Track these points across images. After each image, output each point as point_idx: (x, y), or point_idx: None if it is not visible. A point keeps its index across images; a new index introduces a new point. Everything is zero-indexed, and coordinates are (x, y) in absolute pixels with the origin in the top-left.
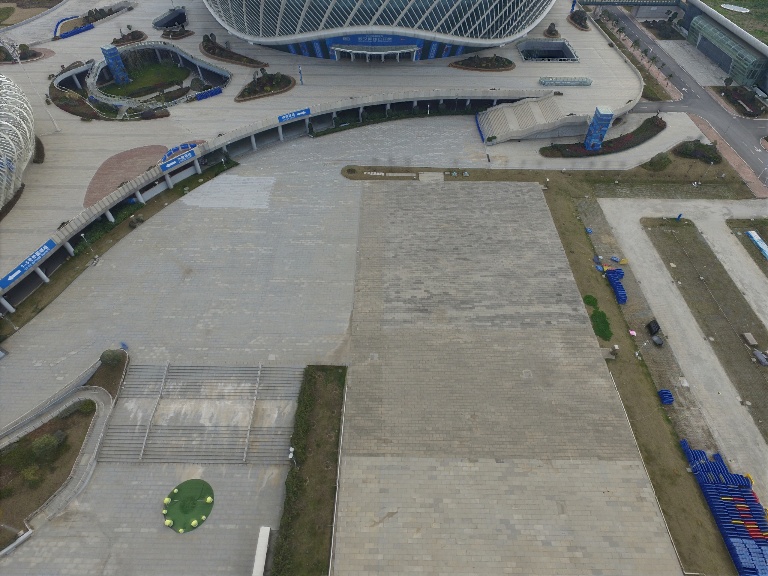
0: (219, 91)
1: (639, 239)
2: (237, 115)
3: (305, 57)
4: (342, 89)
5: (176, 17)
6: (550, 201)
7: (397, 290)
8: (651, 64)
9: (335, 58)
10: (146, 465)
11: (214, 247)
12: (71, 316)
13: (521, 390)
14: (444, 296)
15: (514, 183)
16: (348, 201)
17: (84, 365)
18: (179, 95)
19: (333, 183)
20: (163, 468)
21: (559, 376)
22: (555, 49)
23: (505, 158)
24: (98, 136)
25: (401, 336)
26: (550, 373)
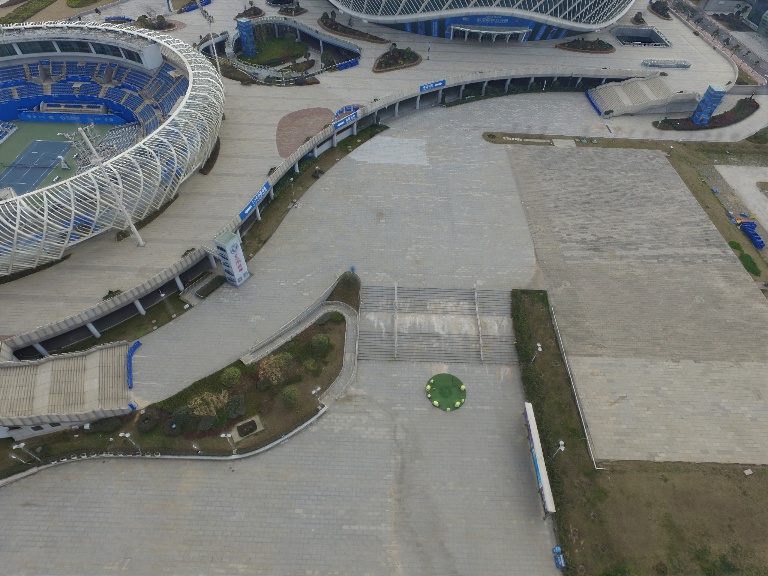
0: (356, 63)
1: (760, 199)
2: (381, 84)
3: (420, 35)
4: (466, 64)
5: None
6: (675, 166)
7: (568, 233)
8: (734, 52)
9: (449, 37)
10: (399, 363)
11: (395, 195)
12: (294, 247)
13: (698, 311)
14: (610, 239)
15: (640, 150)
16: (498, 161)
17: (322, 285)
18: (307, 67)
19: (479, 146)
20: (414, 365)
21: (726, 301)
22: (643, 36)
23: (624, 129)
24: (264, 98)
25: (584, 269)
26: (718, 299)
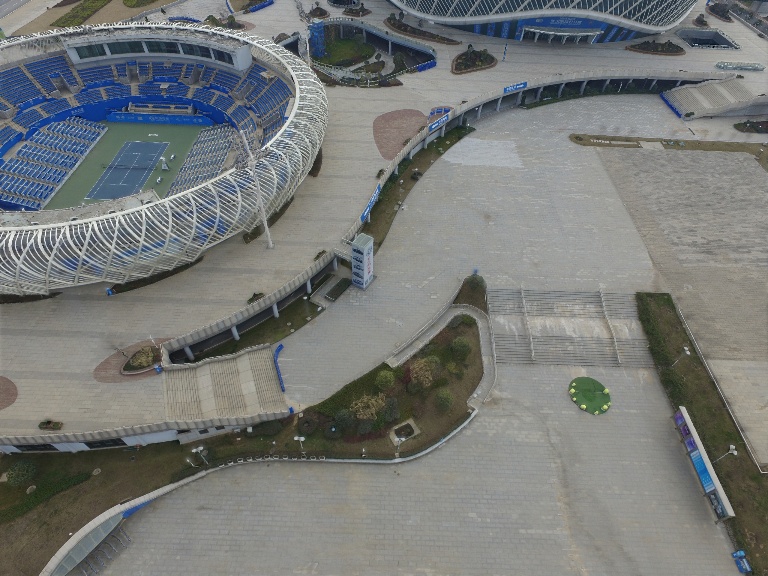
0: (434, 64)
1: None
2: (464, 86)
3: (489, 37)
4: (543, 66)
5: None
6: (767, 169)
7: (677, 236)
8: None
9: (519, 39)
10: (536, 366)
11: (498, 198)
12: (410, 249)
13: None
14: (720, 242)
15: (728, 153)
16: (591, 163)
17: (448, 287)
18: (379, 68)
19: (569, 148)
20: (552, 368)
21: None
22: (706, 38)
23: (707, 132)
24: (352, 100)
25: (702, 272)
26: None
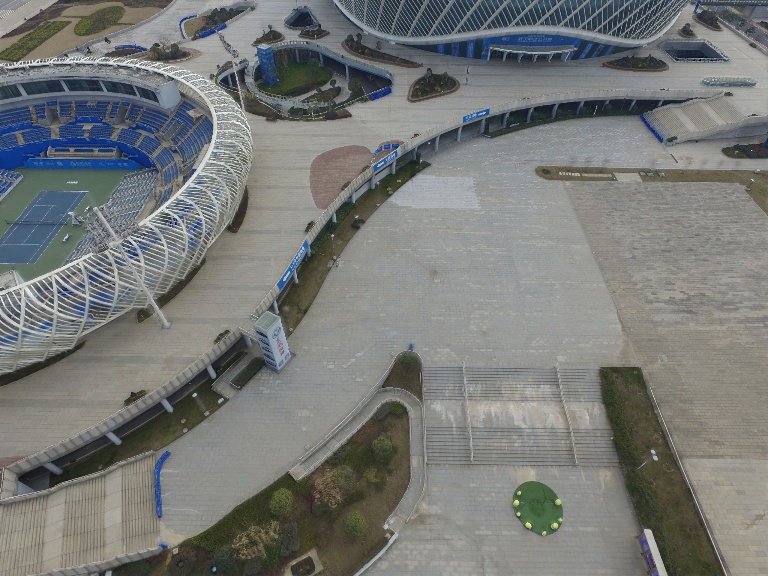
0: (389, 91)
1: None
2: (419, 115)
3: (454, 57)
4: (509, 89)
5: (298, 17)
6: (759, 202)
7: (652, 291)
8: None
9: (486, 58)
10: (476, 467)
11: (447, 248)
12: (339, 317)
13: None
14: (702, 297)
15: (715, 184)
16: (558, 202)
17: (377, 367)
18: (333, 95)
19: (534, 184)
20: (494, 470)
21: None
22: (693, 49)
23: (691, 159)
24: (292, 136)
25: (680, 337)
26: None
